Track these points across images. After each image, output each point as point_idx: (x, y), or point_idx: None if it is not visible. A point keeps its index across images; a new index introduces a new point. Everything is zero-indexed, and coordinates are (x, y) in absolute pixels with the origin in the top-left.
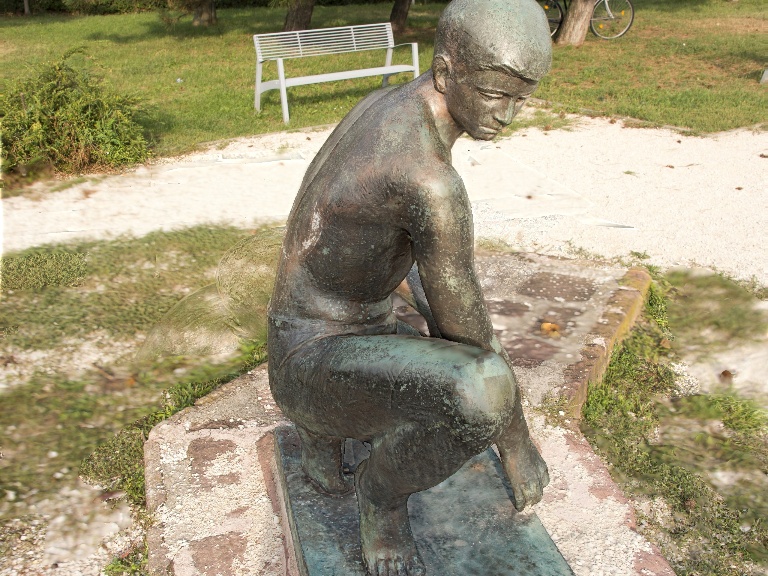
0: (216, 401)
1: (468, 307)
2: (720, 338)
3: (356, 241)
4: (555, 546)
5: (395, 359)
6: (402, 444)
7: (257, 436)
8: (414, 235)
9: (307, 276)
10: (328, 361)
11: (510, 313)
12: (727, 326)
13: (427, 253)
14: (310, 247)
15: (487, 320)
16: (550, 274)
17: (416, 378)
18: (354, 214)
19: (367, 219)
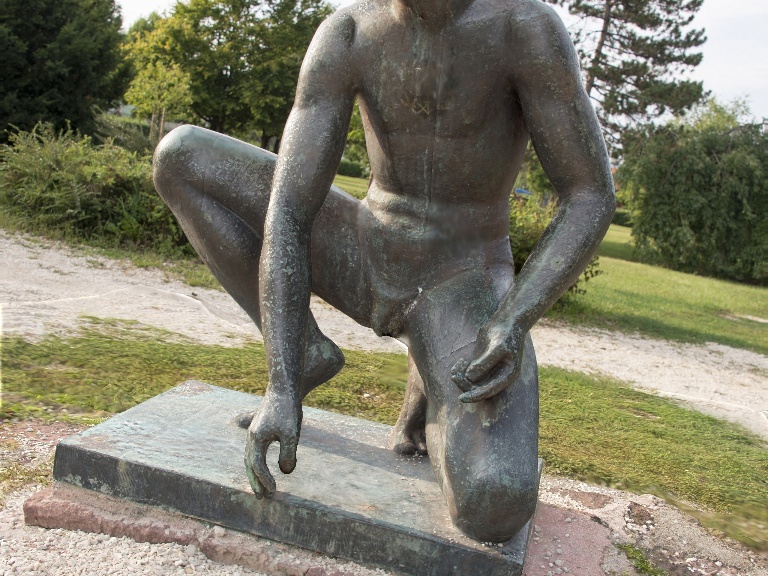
0: (707, 533)
1: None
2: None
3: None
4: (182, 472)
5: None
6: None
7: None
8: None
9: None
10: None
11: None
12: None
13: None
14: None
15: (278, 168)
16: None
17: None
18: None
19: None
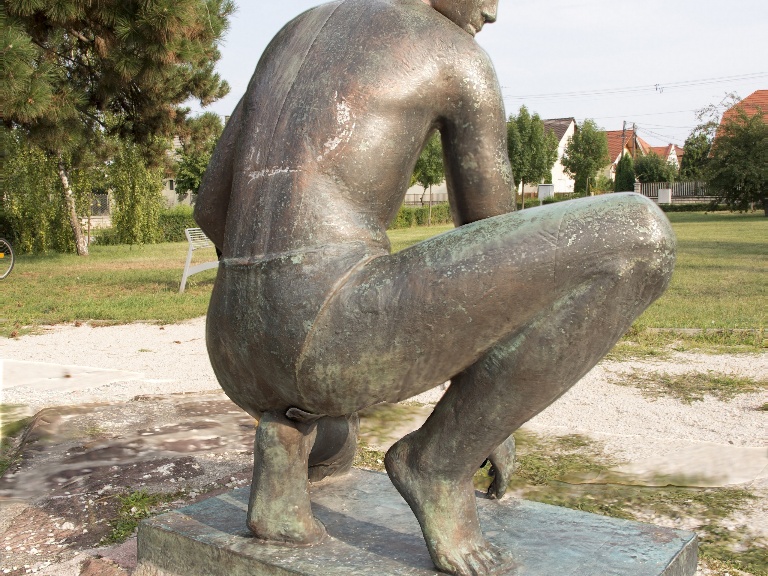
0: None
1: (514, 201)
2: (376, 425)
3: (399, 130)
4: None
5: (540, 218)
6: (574, 316)
7: (73, 569)
8: (463, 117)
9: (335, 186)
10: (421, 265)
11: (206, 426)
12: (374, 416)
13: (480, 136)
14: (339, 145)
15: None
16: (194, 402)
17: (587, 222)
18: (398, 95)
19: (413, 100)
